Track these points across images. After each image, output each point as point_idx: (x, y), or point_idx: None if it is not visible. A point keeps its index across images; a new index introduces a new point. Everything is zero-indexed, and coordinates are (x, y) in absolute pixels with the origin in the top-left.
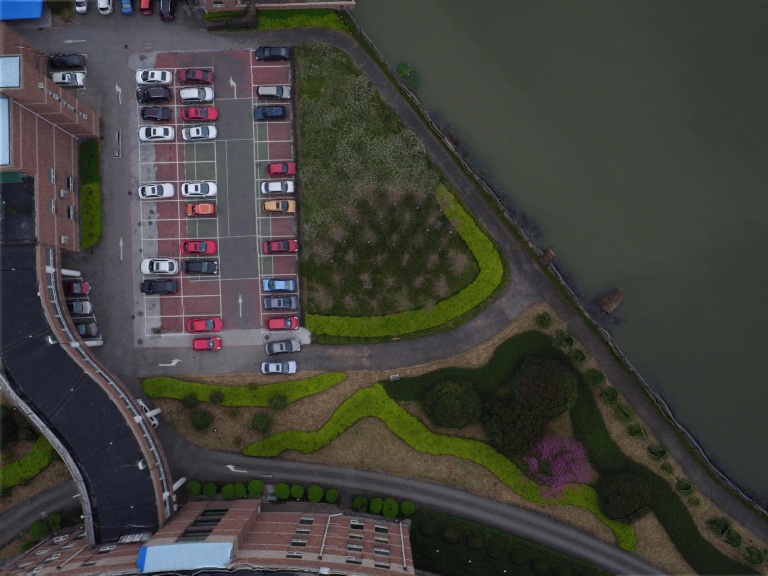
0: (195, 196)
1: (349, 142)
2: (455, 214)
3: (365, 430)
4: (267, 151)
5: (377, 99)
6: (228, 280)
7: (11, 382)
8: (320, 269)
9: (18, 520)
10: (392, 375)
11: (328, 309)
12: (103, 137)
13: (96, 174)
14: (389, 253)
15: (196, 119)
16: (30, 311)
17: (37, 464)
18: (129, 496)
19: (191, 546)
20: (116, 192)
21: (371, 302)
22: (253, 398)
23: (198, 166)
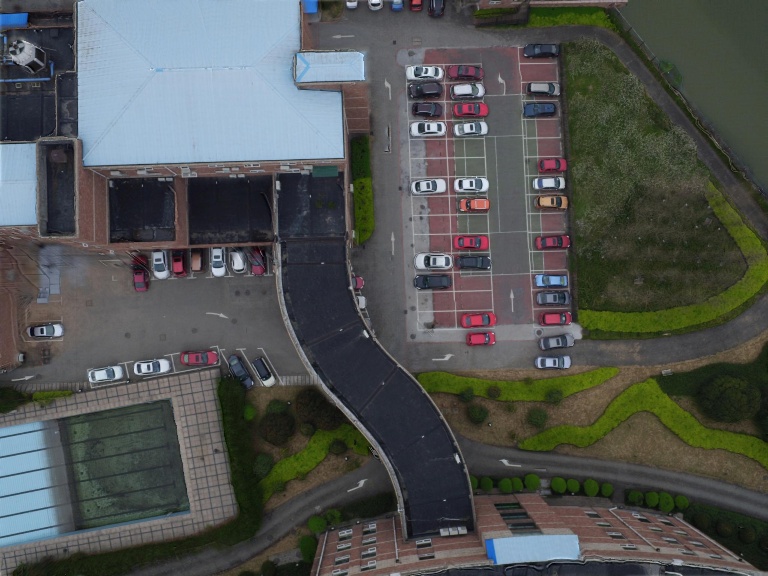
0: (468, 192)
1: (622, 139)
2: (724, 211)
3: (637, 425)
4: (536, 147)
5: (644, 97)
6: (500, 275)
7: (321, 375)
8: (590, 265)
9: (292, 514)
10: (664, 370)
11: (599, 304)
12: (373, 132)
13: (368, 169)
14: (659, 249)
15: (468, 115)
16: (339, 305)
17: (314, 458)
18: (440, 489)
19: (537, 538)
20: (387, 187)
21: (642, 298)
22: (529, 393)
23: (468, 162)
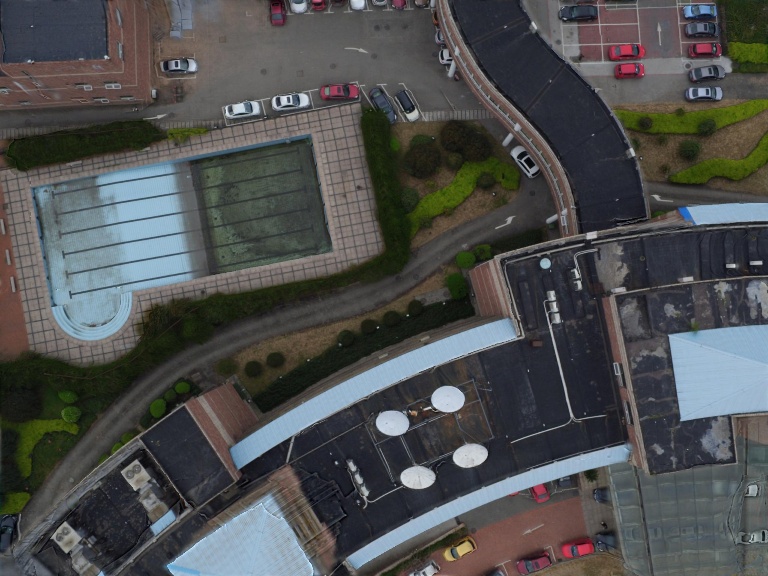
0: None
1: None
2: None
3: None
4: None
5: None
6: (646, 8)
7: (486, 74)
8: None
9: (439, 253)
10: None
11: (749, 37)
12: None
13: None
14: None
15: None
16: (502, 2)
17: (461, 193)
18: (612, 190)
19: (734, 205)
20: None
21: None
22: (680, 124)
23: None
